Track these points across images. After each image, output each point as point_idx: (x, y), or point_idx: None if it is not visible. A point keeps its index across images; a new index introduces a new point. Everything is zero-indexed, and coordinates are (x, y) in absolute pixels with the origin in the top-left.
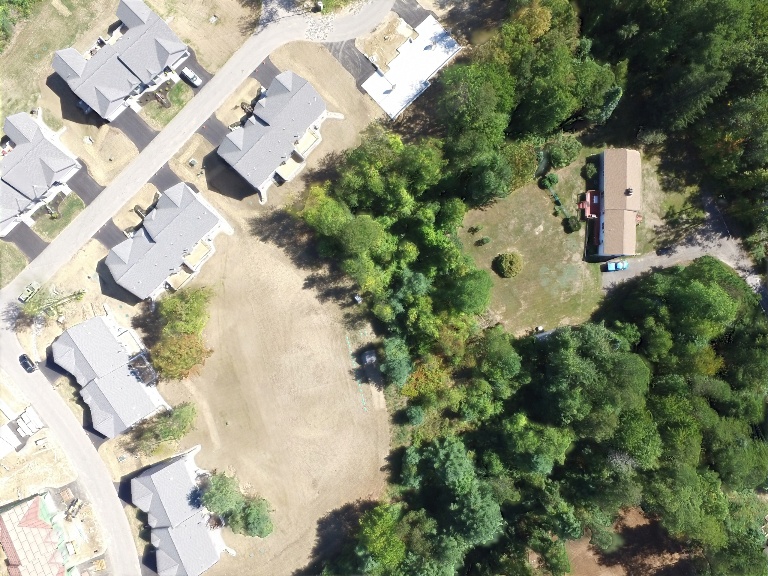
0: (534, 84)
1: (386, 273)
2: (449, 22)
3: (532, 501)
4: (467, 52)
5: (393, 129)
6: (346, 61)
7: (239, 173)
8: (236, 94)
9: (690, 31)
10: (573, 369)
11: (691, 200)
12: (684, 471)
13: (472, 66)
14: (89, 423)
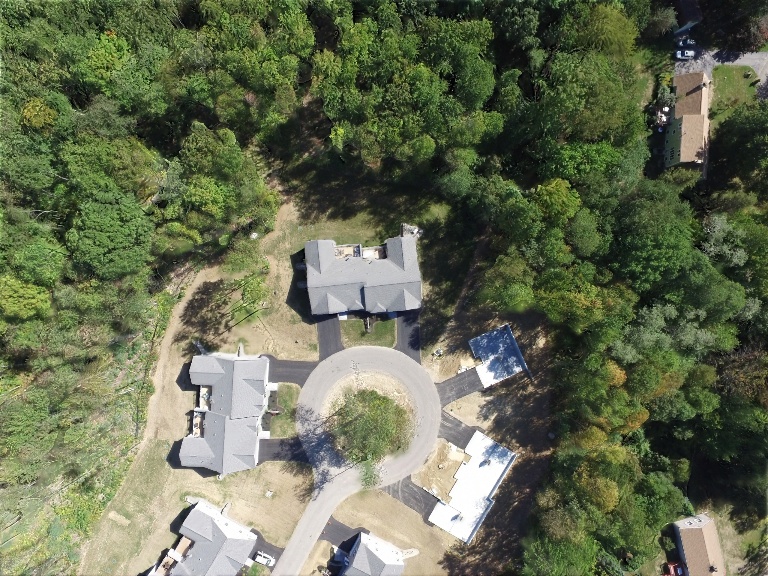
0: (610, 536)
1: None
2: (496, 431)
3: None
4: (521, 458)
5: (469, 551)
6: (407, 499)
7: None
8: (310, 559)
9: (749, 447)
10: None
11: (767, 531)
12: None
13: (555, 568)
14: None
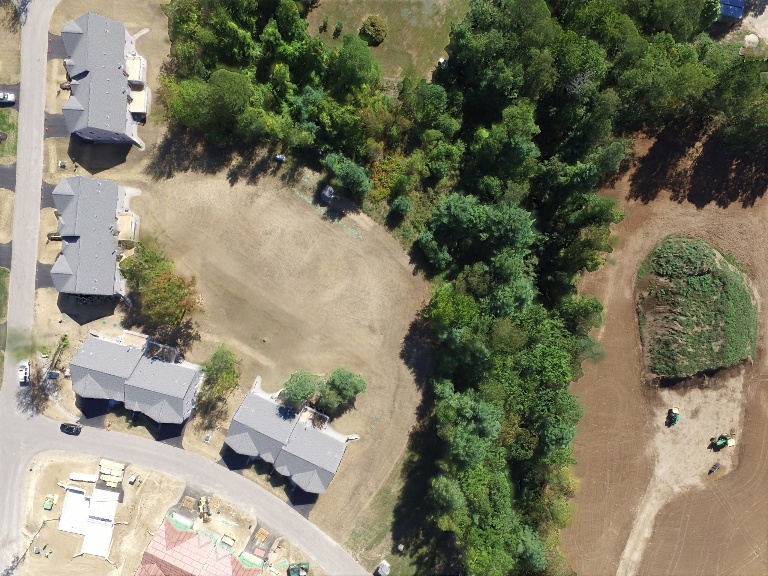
0: None
1: (284, 118)
2: None
3: (548, 193)
4: None
5: None
6: None
7: (99, 131)
8: (50, 83)
9: None
10: (479, 43)
11: None
12: (631, 44)
13: None
14: (158, 433)
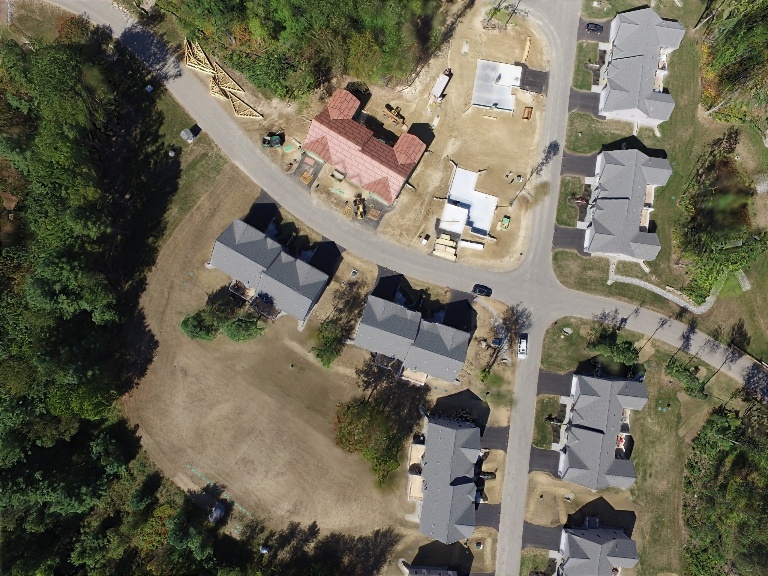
0: None
1: None
2: None
3: None
4: None
5: None
6: None
7: None
8: None
9: None
10: None
11: None
12: None
13: None
14: (401, 281)
